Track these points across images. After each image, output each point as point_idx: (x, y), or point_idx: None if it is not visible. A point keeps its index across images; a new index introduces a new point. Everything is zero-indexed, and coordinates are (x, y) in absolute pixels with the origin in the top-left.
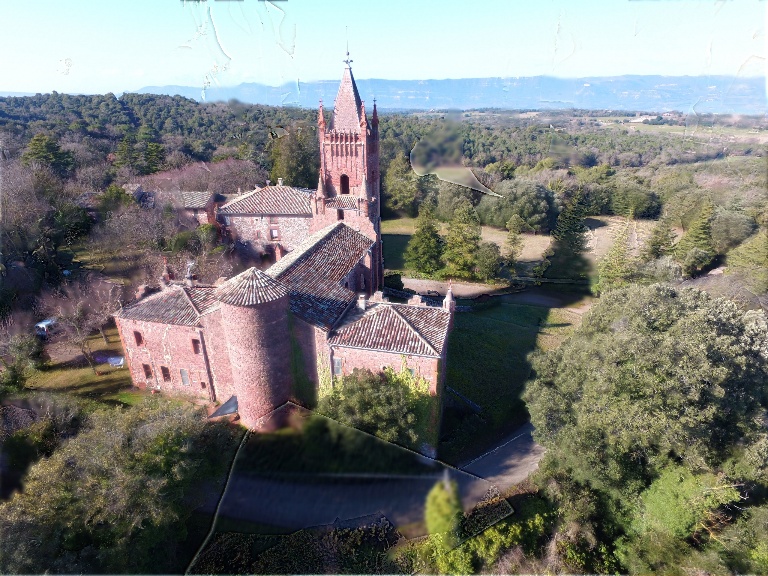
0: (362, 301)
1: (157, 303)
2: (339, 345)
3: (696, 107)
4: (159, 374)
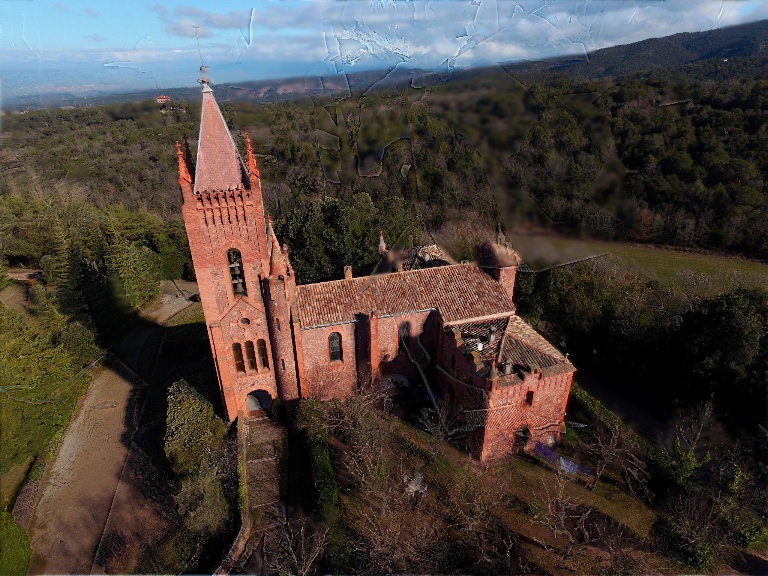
0: (428, 254)
1: (533, 343)
2: None
3: None
4: None
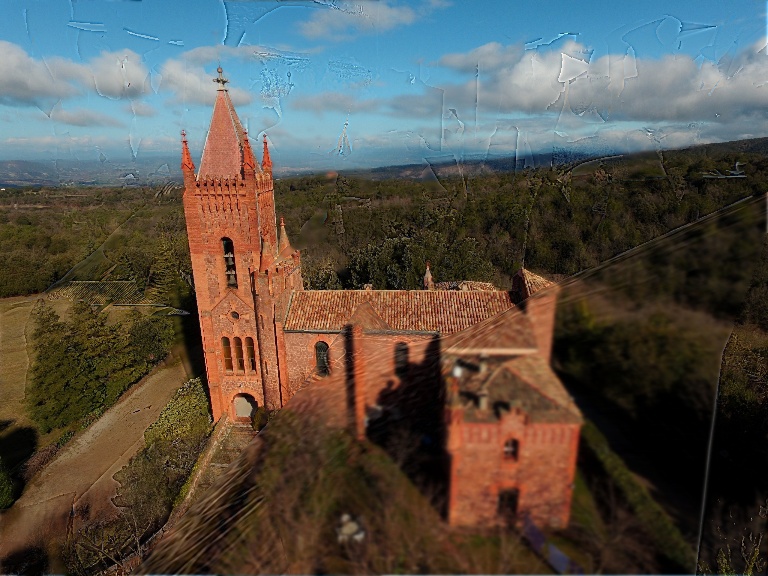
0: None
1: None
2: None
3: (66, 163)
4: None
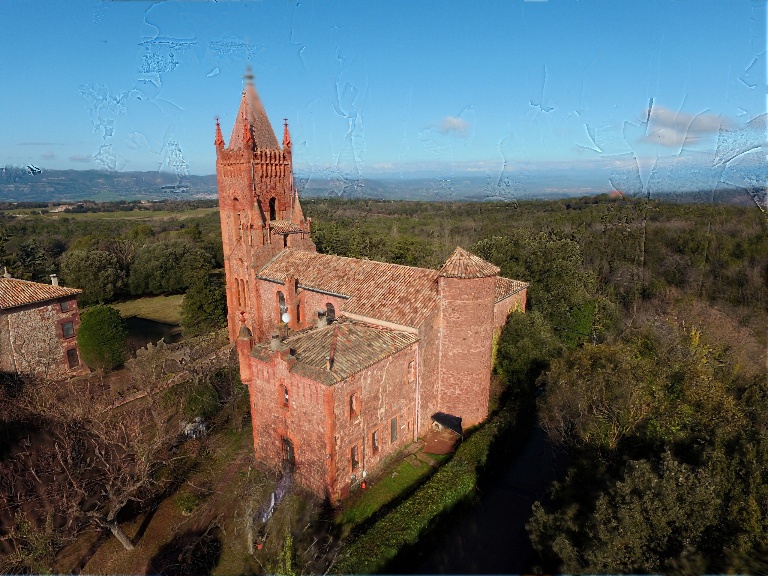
0: None
1: (346, 347)
2: (497, 301)
3: (300, 165)
4: (368, 449)
